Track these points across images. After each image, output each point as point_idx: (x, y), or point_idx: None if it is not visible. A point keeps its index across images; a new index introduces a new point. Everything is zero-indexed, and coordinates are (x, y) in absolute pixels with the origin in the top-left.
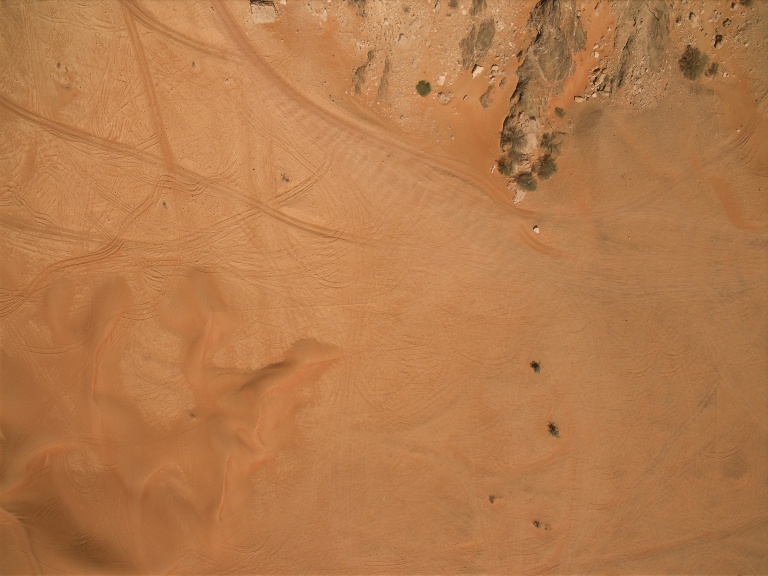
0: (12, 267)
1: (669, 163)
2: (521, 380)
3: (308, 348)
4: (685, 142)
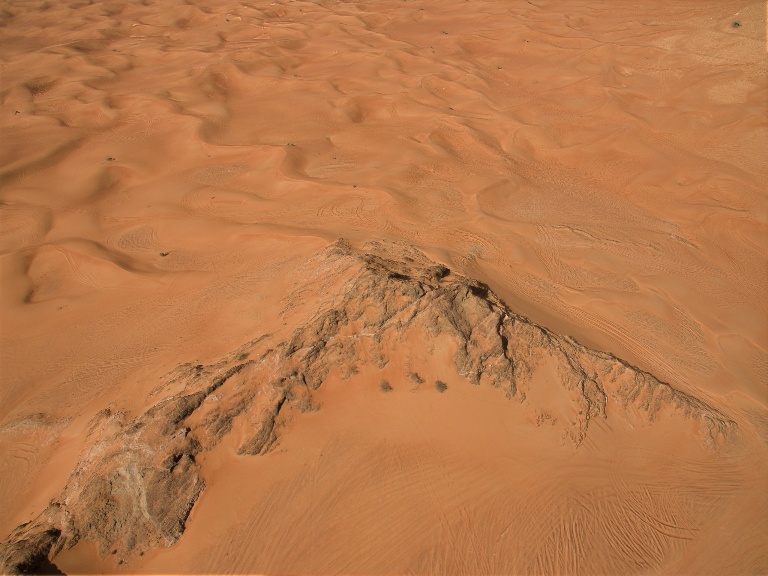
0: (686, 62)
1: None
2: None
3: None
4: None
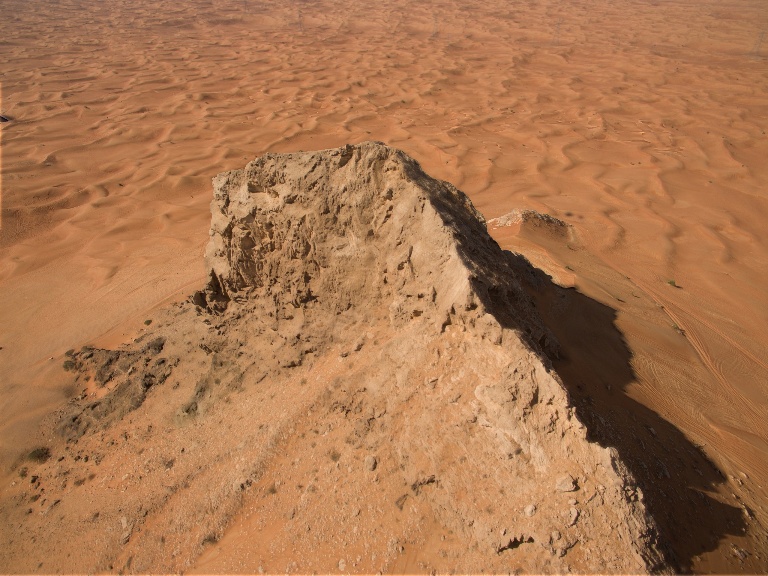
0: None
1: (7, 427)
2: (2, 343)
3: (106, 283)
4: (7, 439)
